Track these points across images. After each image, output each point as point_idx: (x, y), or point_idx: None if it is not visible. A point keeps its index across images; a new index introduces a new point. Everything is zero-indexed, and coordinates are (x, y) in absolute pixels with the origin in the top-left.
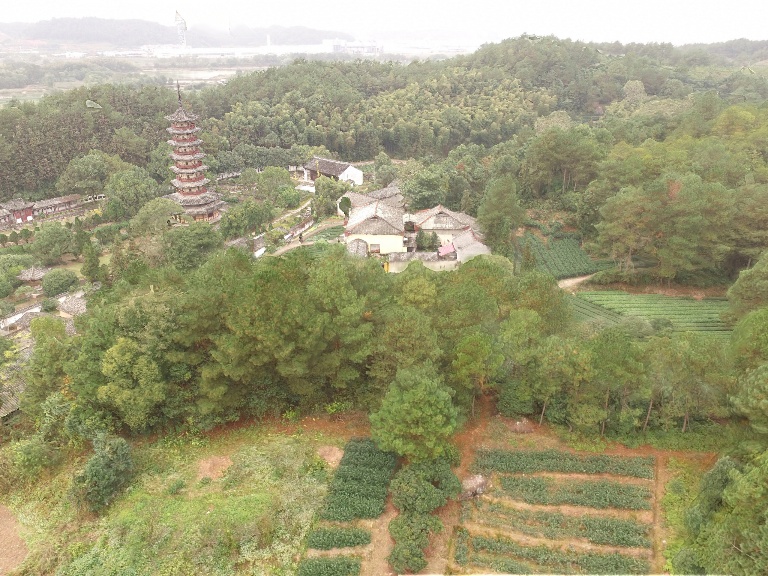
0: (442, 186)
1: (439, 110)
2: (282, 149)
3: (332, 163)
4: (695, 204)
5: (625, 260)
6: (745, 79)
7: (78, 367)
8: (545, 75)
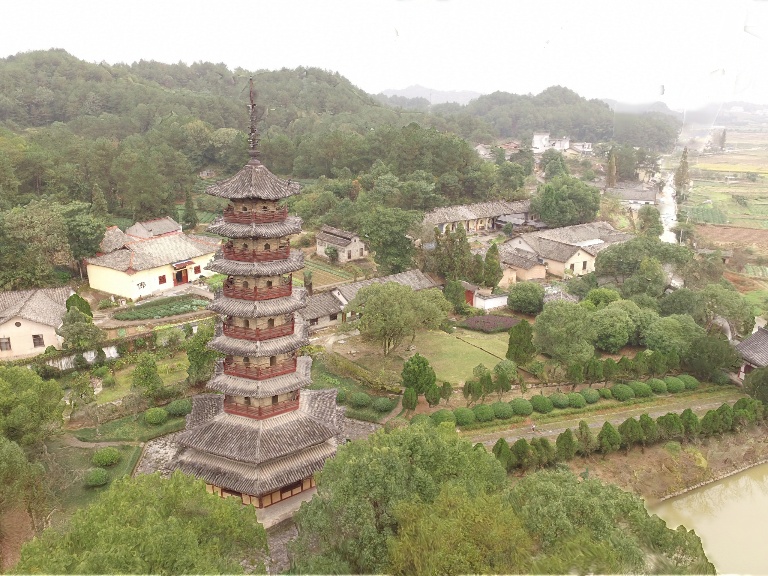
0: None
1: None
2: None
3: None
4: None
5: None
6: None
7: None
8: None
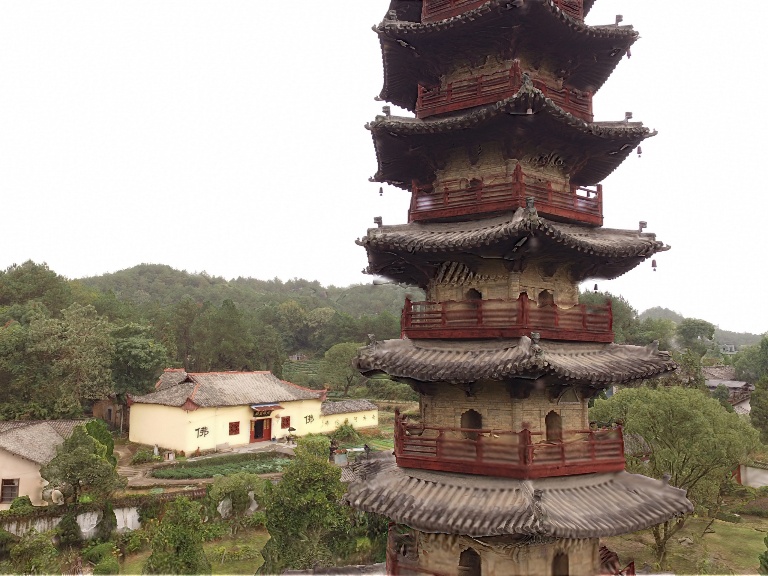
0: None
1: None
2: None
3: None
4: None
5: None
6: None
7: None
8: None
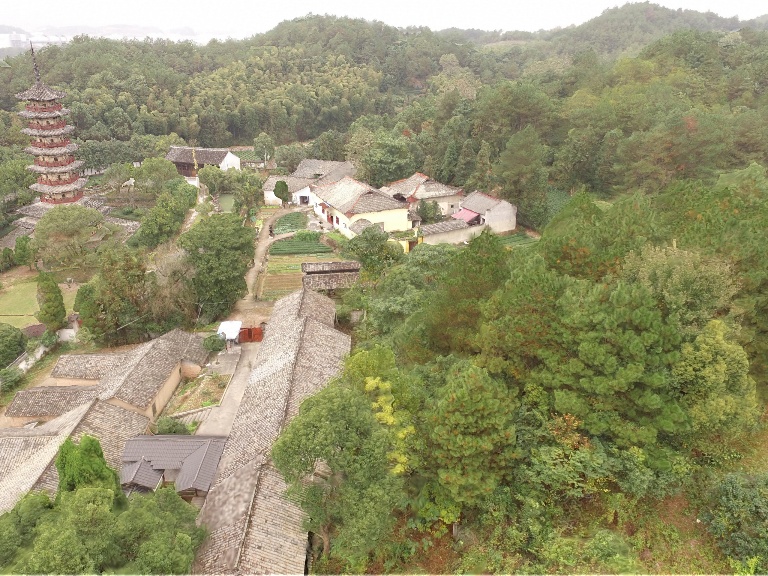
0: (409, 153)
1: (284, 88)
2: (121, 142)
3: (202, 151)
4: (718, 133)
5: (655, 196)
6: (530, 51)
7: (614, 391)
8: (359, 52)
